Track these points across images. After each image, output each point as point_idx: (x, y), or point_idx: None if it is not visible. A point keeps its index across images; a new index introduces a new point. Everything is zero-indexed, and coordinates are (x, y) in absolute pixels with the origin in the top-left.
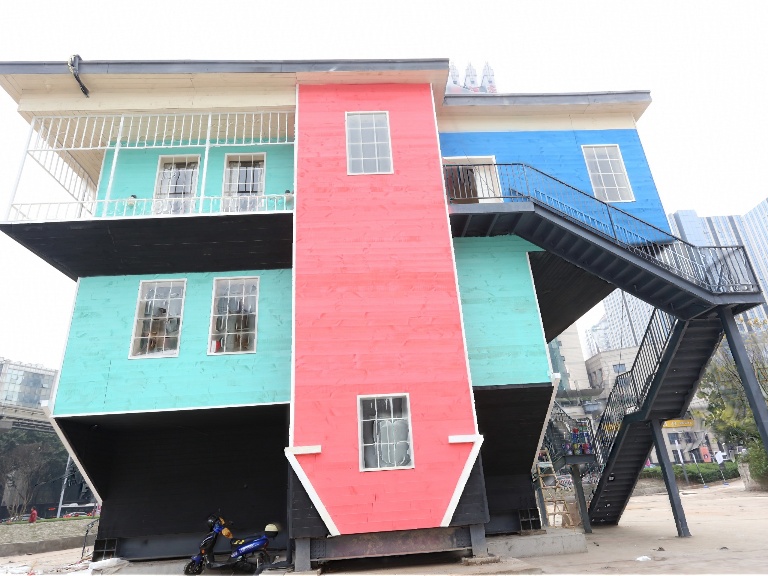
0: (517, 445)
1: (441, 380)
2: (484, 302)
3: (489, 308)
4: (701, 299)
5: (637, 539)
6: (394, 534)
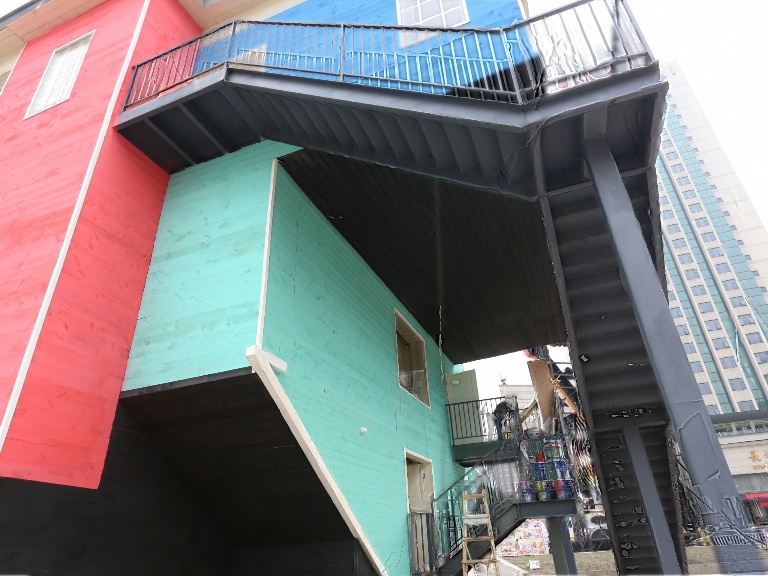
0: (289, 489)
1: None
2: (194, 250)
3: (198, 258)
4: (492, 127)
5: None
6: None
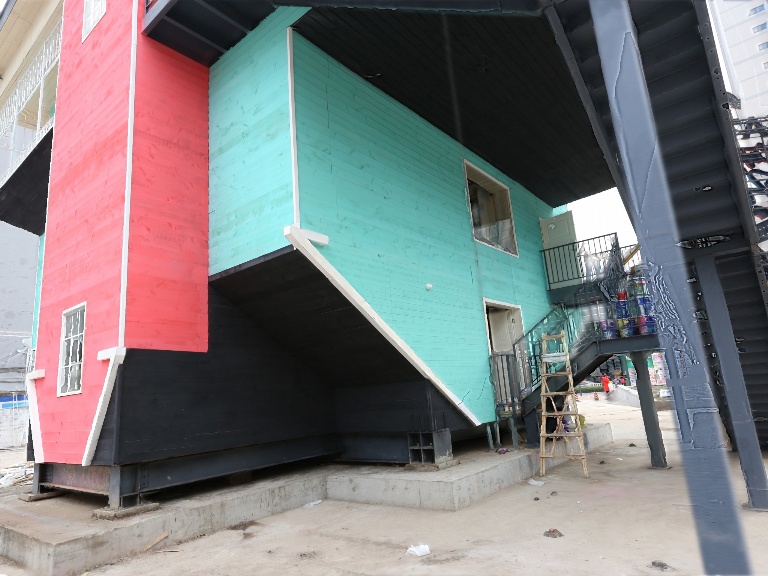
0: (359, 342)
1: (106, 278)
2: (238, 141)
3: (241, 148)
4: None
5: (651, 496)
6: (81, 467)
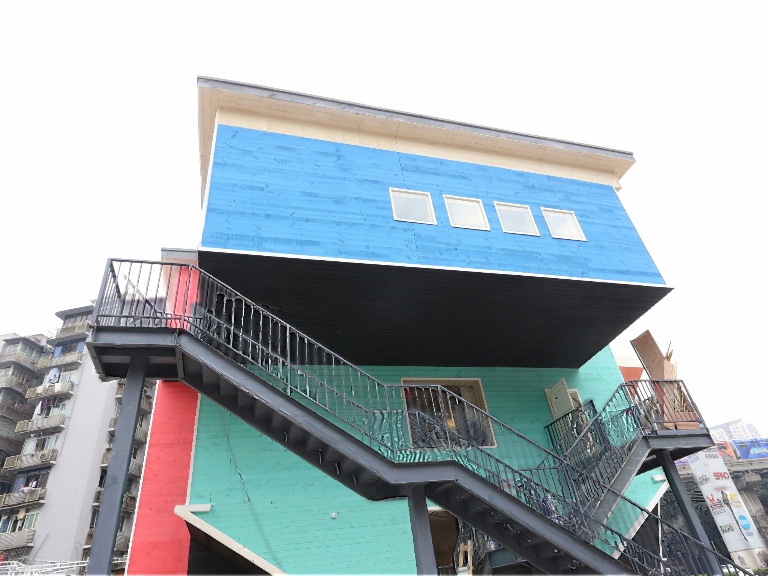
0: None
1: None
2: None
3: None
4: None
5: None
6: None
